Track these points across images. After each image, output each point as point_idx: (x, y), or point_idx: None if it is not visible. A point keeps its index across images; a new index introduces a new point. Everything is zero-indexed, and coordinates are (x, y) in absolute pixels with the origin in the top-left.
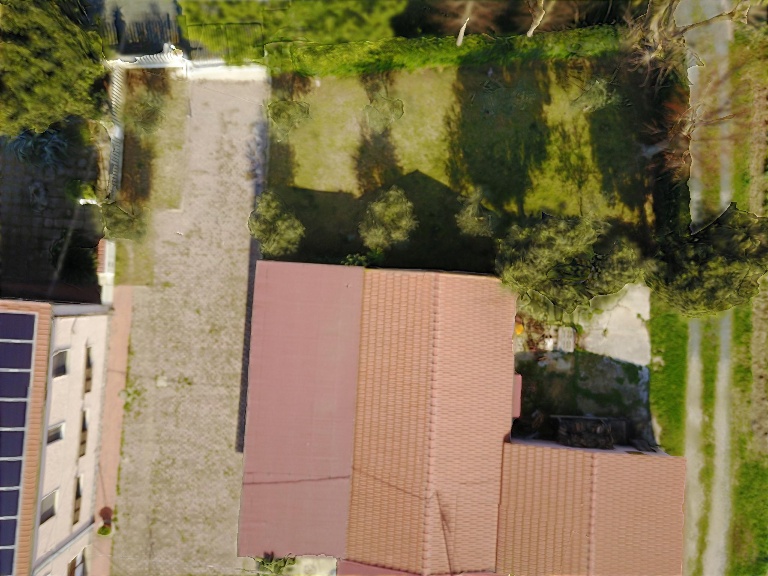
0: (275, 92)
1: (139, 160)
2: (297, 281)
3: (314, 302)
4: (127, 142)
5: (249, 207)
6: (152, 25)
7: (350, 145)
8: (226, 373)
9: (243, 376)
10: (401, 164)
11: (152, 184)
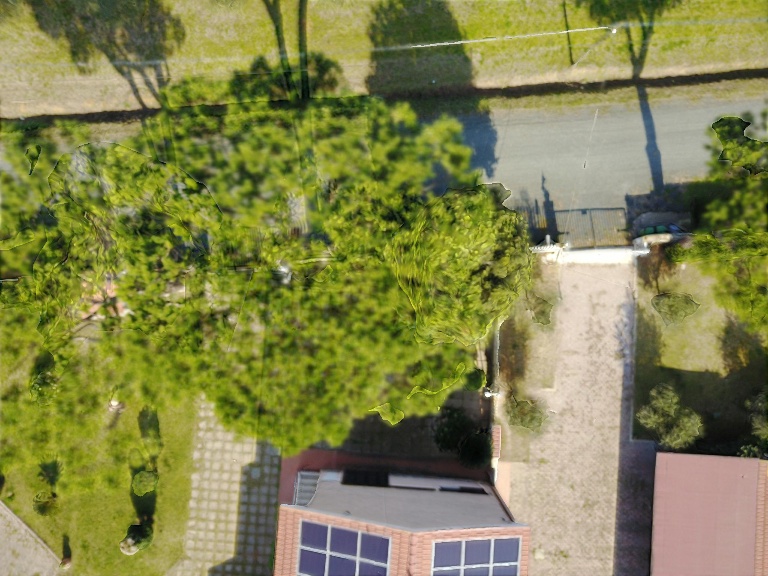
0: (640, 274)
1: (513, 341)
2: (695, 472)
3: (712, 493)
4: (503, 324)
5: (618, 386)
6: (520, 210)
7: (715, 326)
8: (599, 546)
9: (616, 549)
10: (765, 344)
11: (526, 364)
